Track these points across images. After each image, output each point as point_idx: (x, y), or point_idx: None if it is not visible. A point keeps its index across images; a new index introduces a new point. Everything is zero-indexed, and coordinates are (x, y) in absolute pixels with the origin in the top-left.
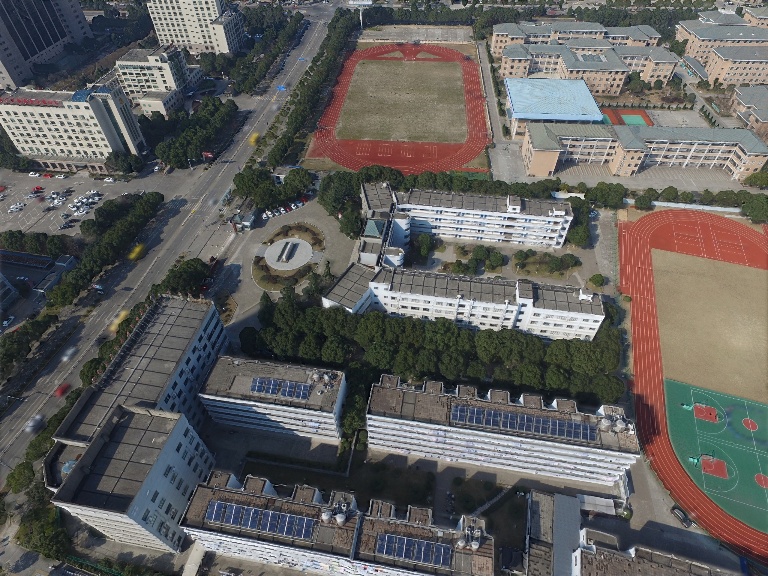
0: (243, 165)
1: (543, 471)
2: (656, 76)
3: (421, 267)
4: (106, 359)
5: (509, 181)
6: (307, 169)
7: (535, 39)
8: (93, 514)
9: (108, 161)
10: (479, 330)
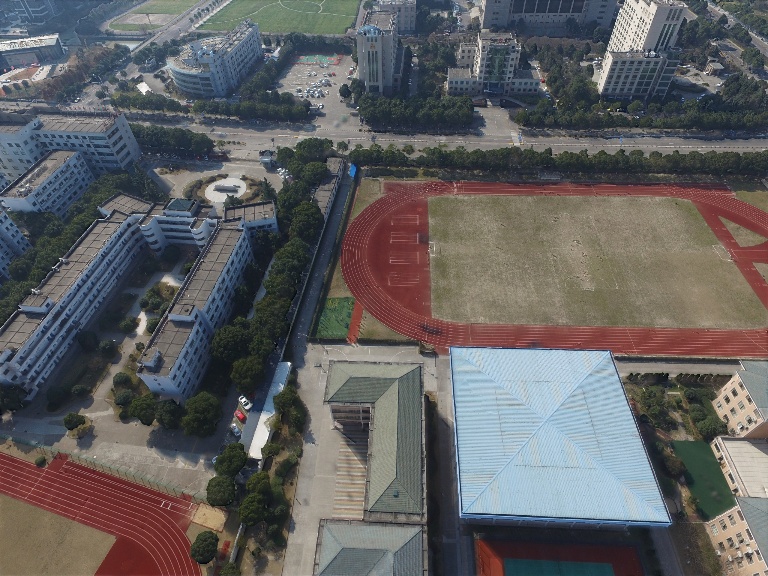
0: (368, 147)
1: None
2: None
3: (177, 270)
4: None
5: (324, 363)
6: None
7: None
8: None
9: None
10: None
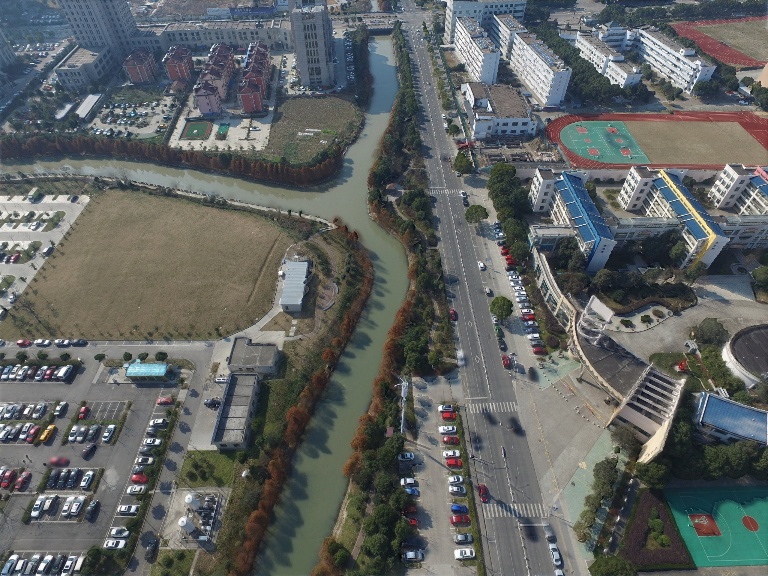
0: None
1: (535, 89)
2: None
3: None
4: None
5: (737, 77)
6: None
7: None
8: (449, 4)
9: None
10: None
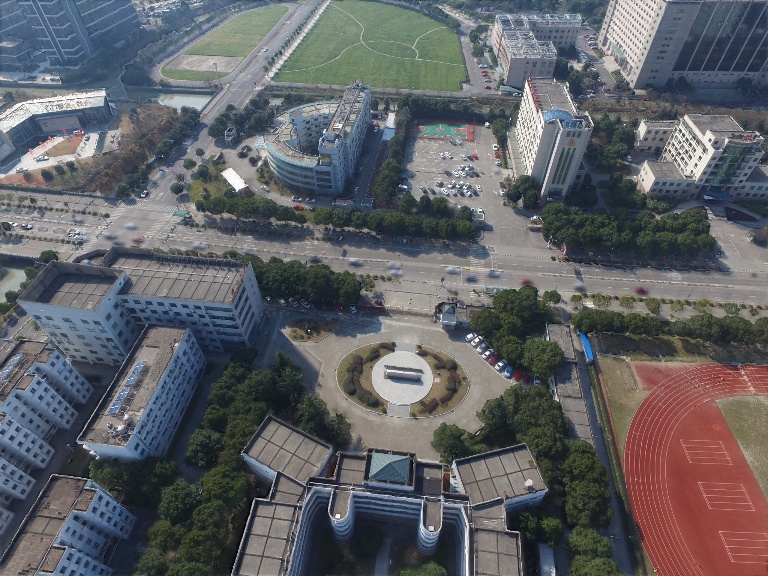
0: (578, 292)
1: None
2: None
3: (383, 575)
4: None
5: None
6: (597, 368)
7: None
8: None
9: (519, 179)
10: None
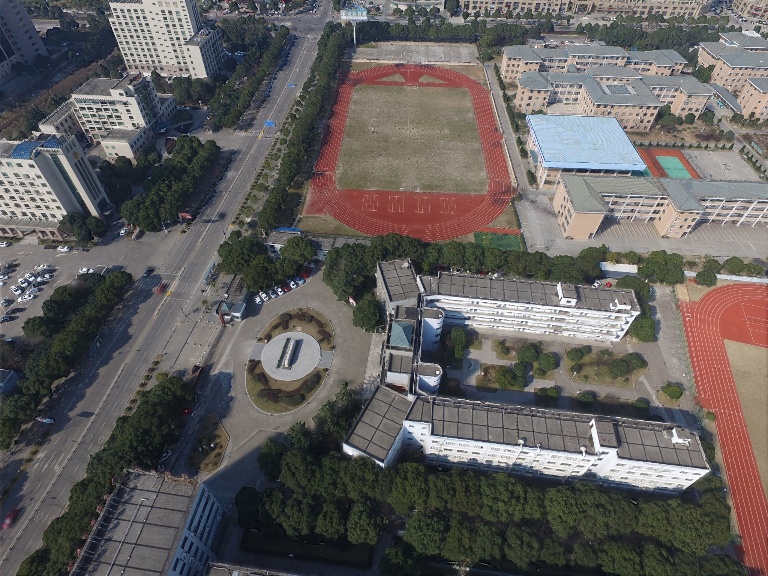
0: (228, 226)
1: None
2: (687, 109)
3: (456, 373)
4: (52, 560)
5: (544, 246)
6: (306, 231)
7: (550, 63)
8: None
9: (62, 226)
10: (541, 473)
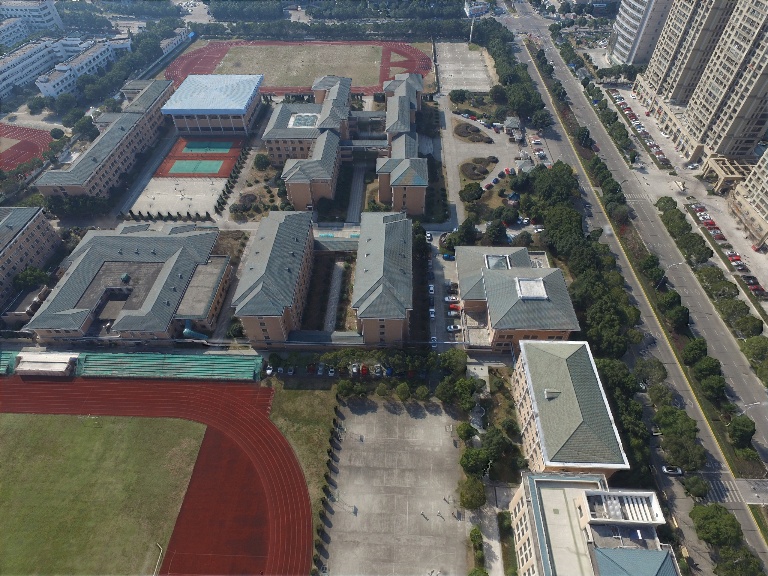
0: None
1: None
2: None
3: None
4: None
5: None
6: None
7: None
8: None
9: None
10: None
